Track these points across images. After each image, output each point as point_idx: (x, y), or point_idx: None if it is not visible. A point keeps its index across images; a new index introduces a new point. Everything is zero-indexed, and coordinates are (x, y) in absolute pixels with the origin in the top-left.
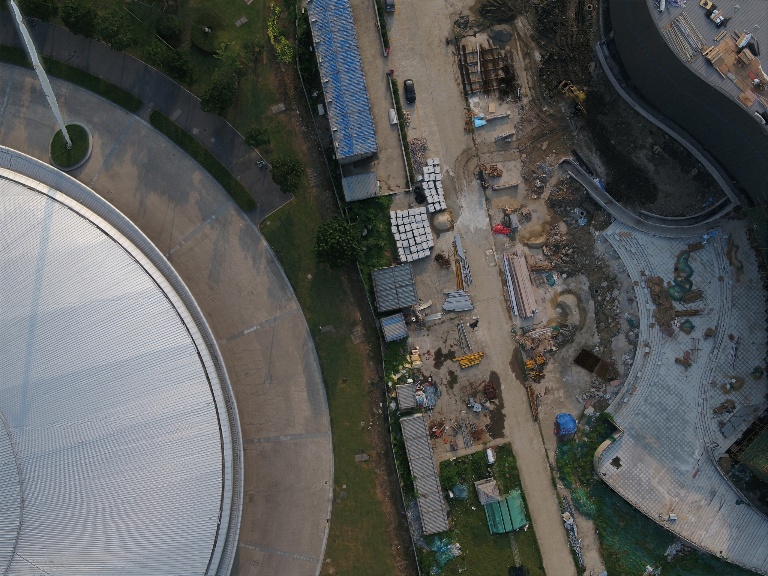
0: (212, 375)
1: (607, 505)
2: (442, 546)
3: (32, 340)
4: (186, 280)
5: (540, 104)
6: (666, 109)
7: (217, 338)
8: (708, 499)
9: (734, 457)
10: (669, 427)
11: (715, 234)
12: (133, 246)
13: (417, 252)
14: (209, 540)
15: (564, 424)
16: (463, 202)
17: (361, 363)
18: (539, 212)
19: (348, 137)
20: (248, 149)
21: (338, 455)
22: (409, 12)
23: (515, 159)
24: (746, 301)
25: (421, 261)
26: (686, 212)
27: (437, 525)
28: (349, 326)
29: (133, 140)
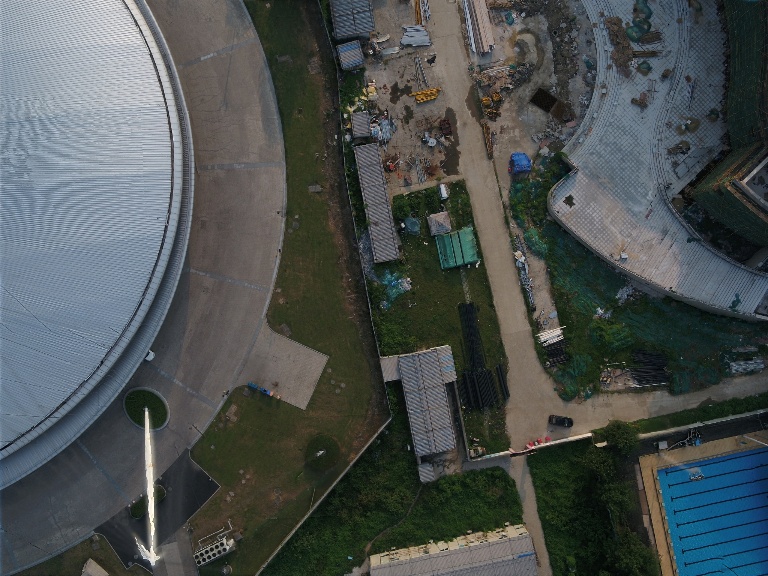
0: (164, 79)
1: (559, 246)
2: (393, 279)
3: None
4: None
5: None
6: None
7: (172, 53)
8: (660, 238)
9: (687, 196)
10: (623, 167)
11: None
12: None
13: None
14: (156, 240)
15: (518, 160)
16: None
17: (317, 94)
18: None
19: None
20: None
21: (291, 185)
22: None
23: None
24: (704, 43)
25: None
26: None
27: (388, 253)
28: (306, 56)
29: None
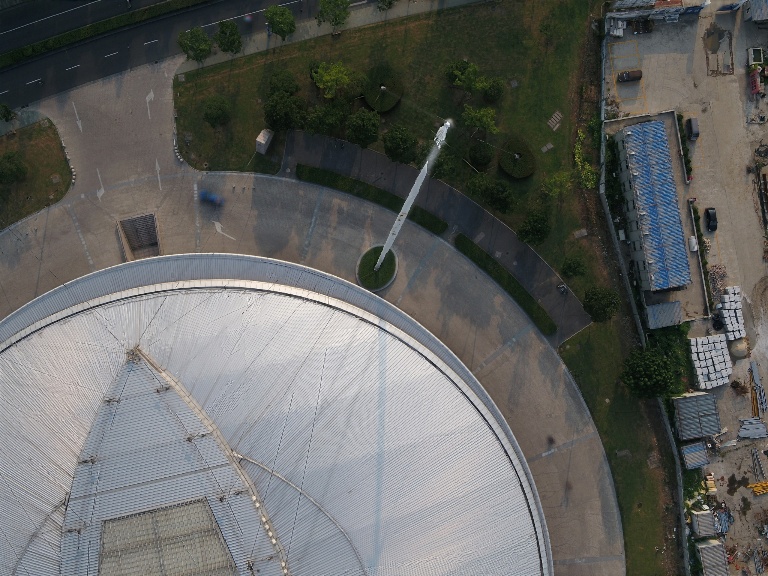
0: (533, 506)
1: None
2: None
3: (381, 478)
4: None
5: None
6: None
7: None
8: None
9: None
10: None
11: None
12: (458, 377)
13: (716, 380)
14: None
15: None
16: (760, 330)
17: (657, 488)
18: None
19: (663, 270)
20: (549, 273)
21: None
22: (710, 140)
23: None
24: None
25: (717, 387)
26: None
27: None
28: (645, 451)
29: (437, 262)
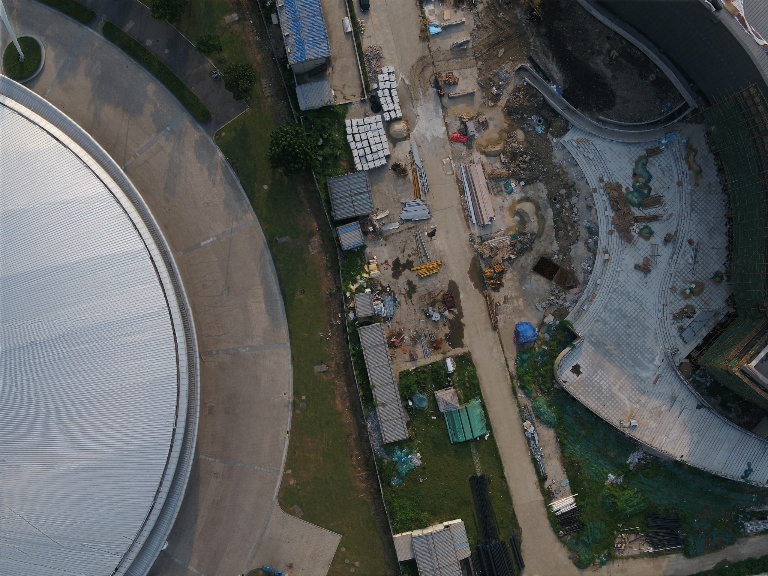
0: (165, 280)
1: (568, 413)
2: (403, 456)
3: None
4: (141, 192)
5: (496, 11)
6: (621, 10)
7: (172, 247)
8: (669, 404)
9: (694, 362)
10: (629, 334)
11: (673, 138)
12: (84, 152)
13: (373, 161)
14: (165, 445)
15: (523, 332)
16: (419, 111)
17: (319, 273)
18: (496, 120)
19: (300, 42)
20: (202, 60)
21: (297, 366)
22: None
23: (471, 67)
24: (705, 206)
25: (378, 170)
26: (644, 118)
27: (396, 433)
28: (306, 236)
29: (86, 52)
